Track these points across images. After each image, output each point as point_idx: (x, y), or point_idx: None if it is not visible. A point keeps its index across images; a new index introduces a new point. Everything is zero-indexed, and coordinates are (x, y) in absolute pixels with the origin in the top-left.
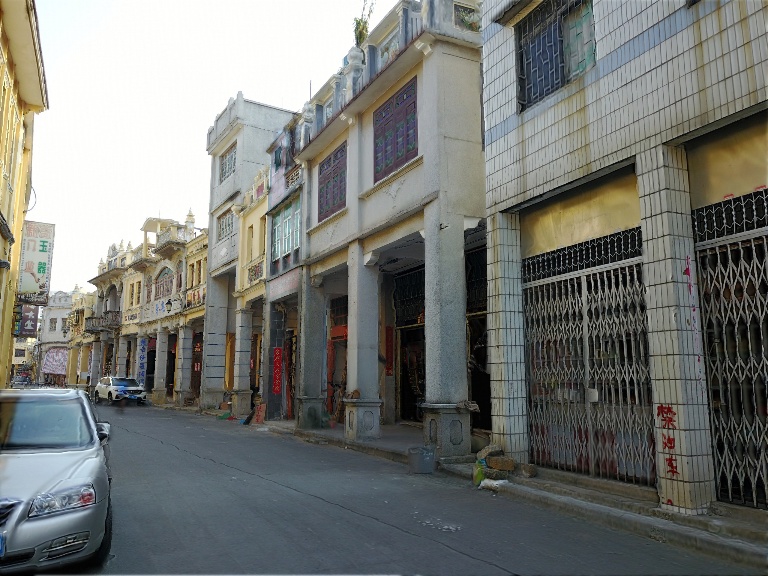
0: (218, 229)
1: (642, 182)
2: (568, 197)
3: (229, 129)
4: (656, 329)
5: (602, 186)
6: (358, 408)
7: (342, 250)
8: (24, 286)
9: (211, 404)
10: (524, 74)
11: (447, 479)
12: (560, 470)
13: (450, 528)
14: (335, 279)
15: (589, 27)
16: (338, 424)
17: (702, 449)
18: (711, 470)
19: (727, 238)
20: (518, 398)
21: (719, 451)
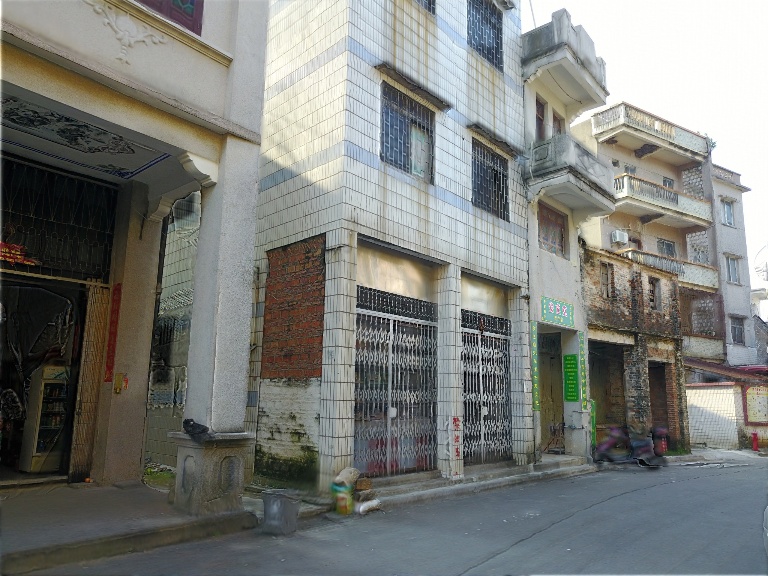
0: None
1: None
2: (389, 253)
3: None
4: None
5: (408, 260)
6: None
7: None
8: None
9: None
10: (383, 129)
11: None
12: None
13: None
14: None
15: (429, 154)
16: None
17: None
18: None
19: None
20: None
21: None
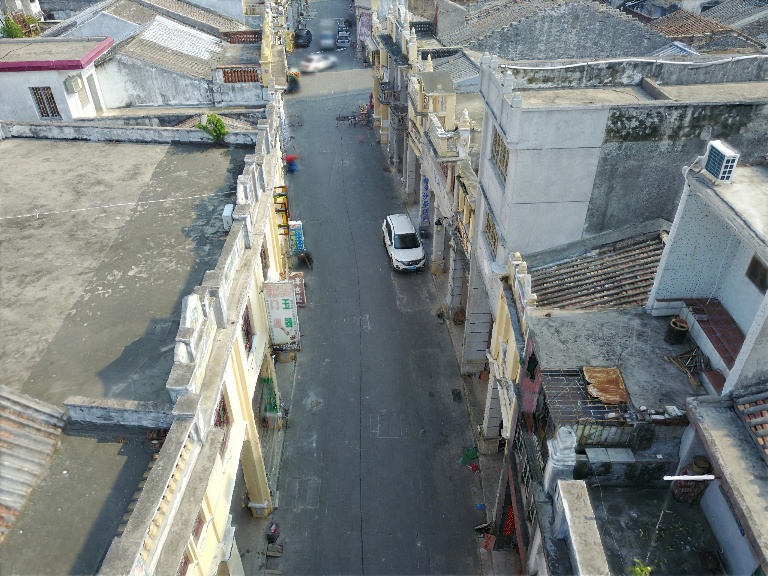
0: (486, 215)
1: None
2: None
3: (499, 131)
4: None
5: None
6: None
7: None
8: (277, 339)
9: (471, 371)
10: None
11: None
12: None
13: None
14: None
15: None
16: None
17: None
18: None
19: None
20: None
21: None
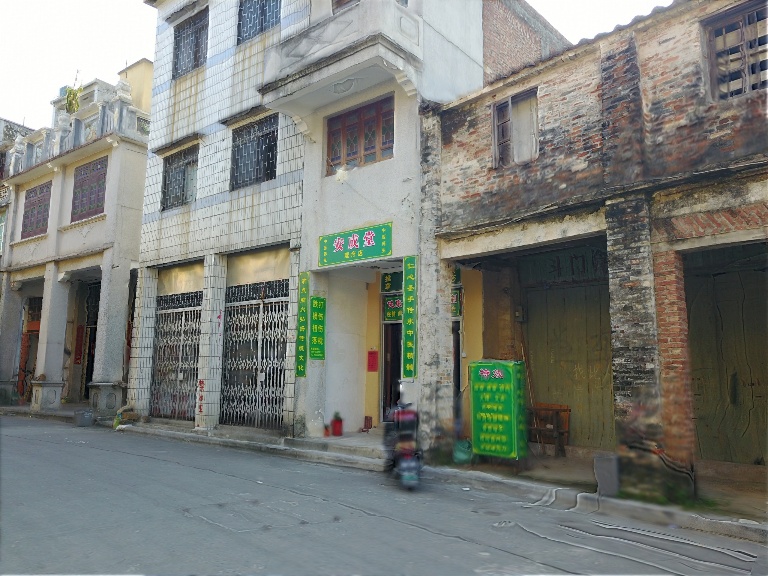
0: None
1: (205, 270)
2: (181, 266)
3: None
4: (202, 344)
5: (196, 264)
6: (43, 387)
7: (41, 266)
8: None
9: None
10: (166, 189)
11: (99, 429)
12: (163, 418)
13: (82, 442)
14: (34, 284)
15: (196, 179)
16: (27, 403)
17: (215, 400)
18: (218, 410)
19: (235, 303)
20: (146, 378)
21: (223, 401)
